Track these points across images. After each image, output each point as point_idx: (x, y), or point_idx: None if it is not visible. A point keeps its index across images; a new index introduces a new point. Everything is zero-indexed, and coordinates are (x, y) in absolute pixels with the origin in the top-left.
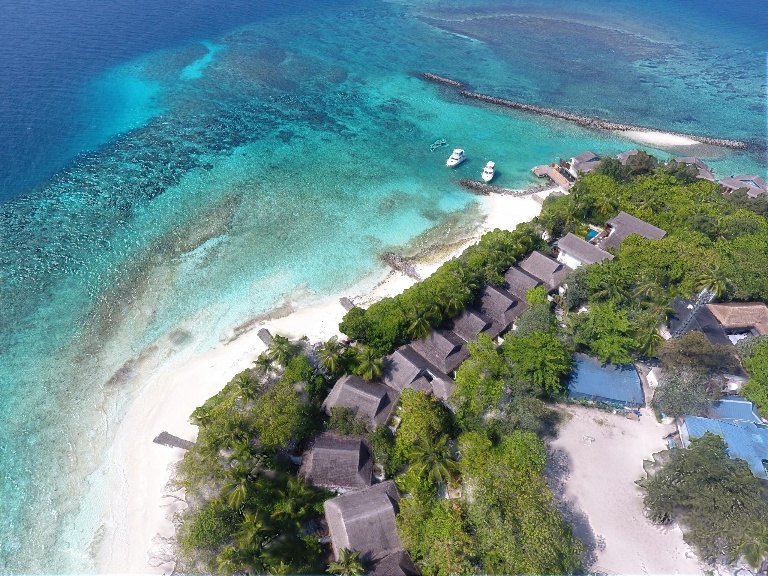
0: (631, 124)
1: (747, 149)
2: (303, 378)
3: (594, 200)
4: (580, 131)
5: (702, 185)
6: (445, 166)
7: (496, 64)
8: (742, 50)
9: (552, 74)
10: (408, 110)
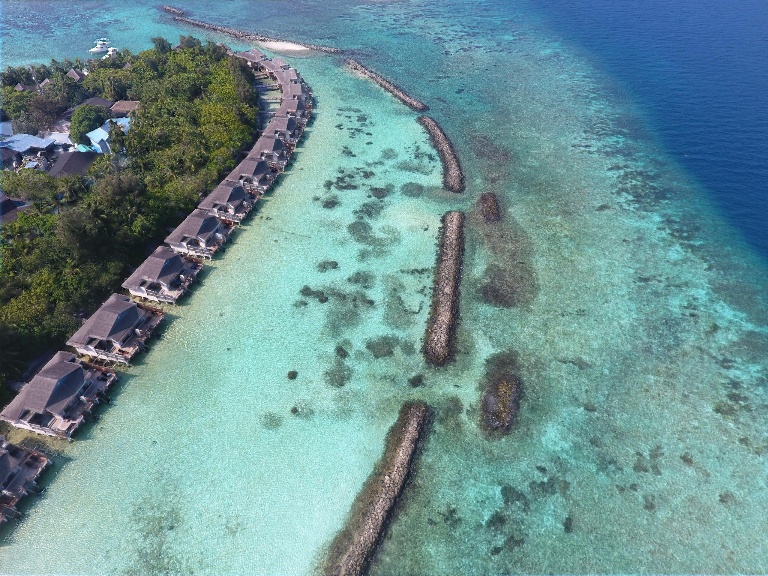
0: (277, 38)
1: (339, 53)
2: None
3: (122, 58)
4: (229, 40)
5: (227, 59)
6: (87, 52)
7: (238, 3)
8: (472, 2)
9: (272, 10)
10: (117, 26)
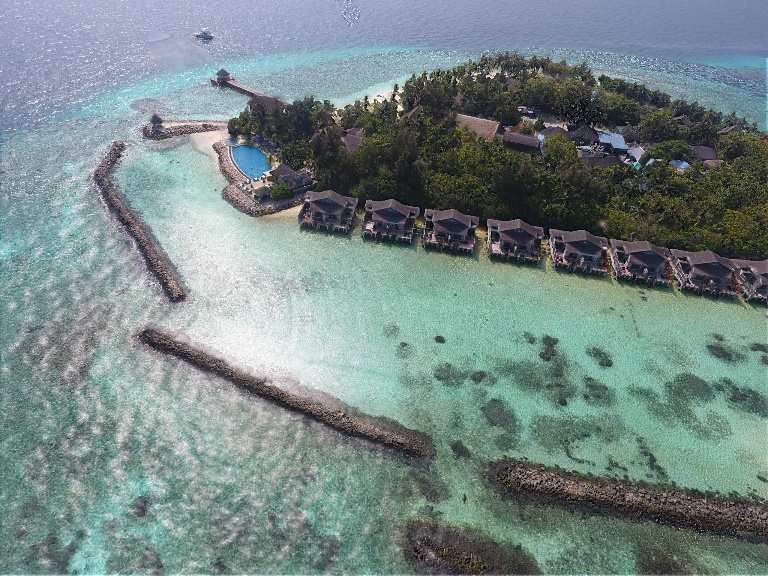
0: None
1: None
2: (574, 72)
3: None
4: None
5: None
6: None
7: None
8: None
9: None
10: None
